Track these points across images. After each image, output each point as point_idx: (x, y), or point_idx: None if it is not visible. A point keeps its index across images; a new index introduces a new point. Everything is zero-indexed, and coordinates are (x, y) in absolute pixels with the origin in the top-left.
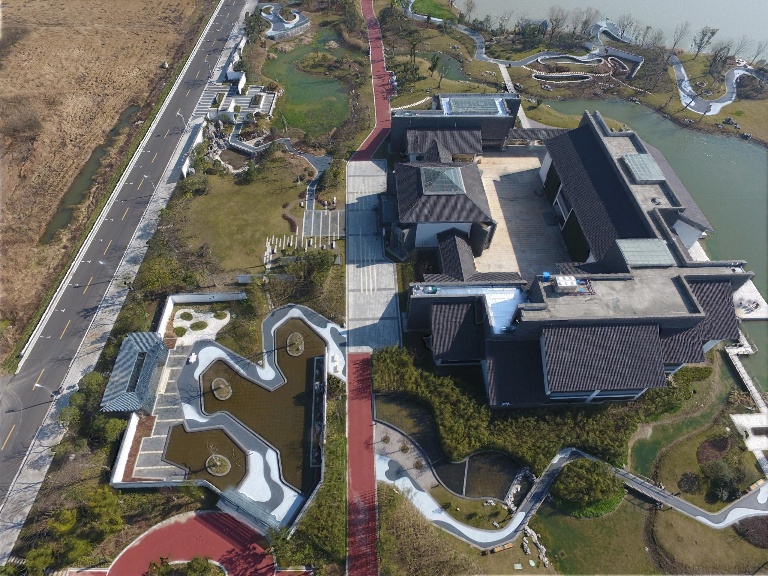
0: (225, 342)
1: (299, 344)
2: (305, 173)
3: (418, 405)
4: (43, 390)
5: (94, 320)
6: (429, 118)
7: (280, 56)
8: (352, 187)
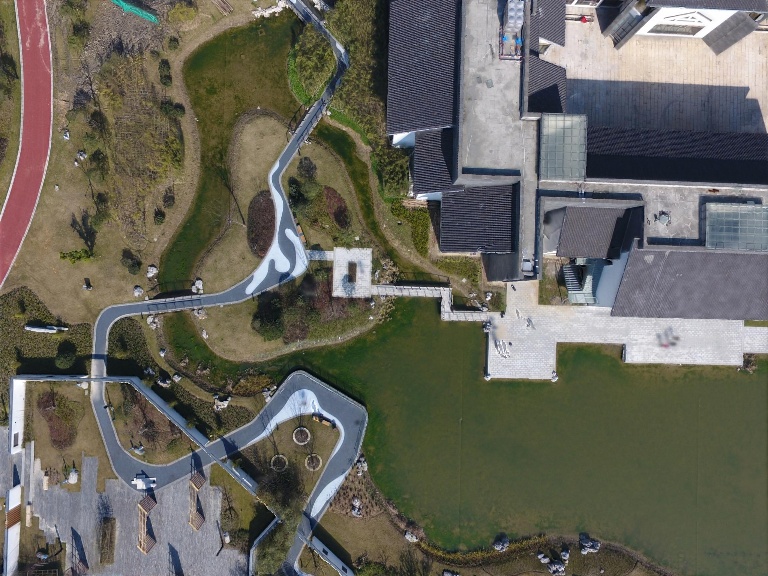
0: None
1: None
2: None
3: None
4: None
5: None
6: None
7: None
8: None
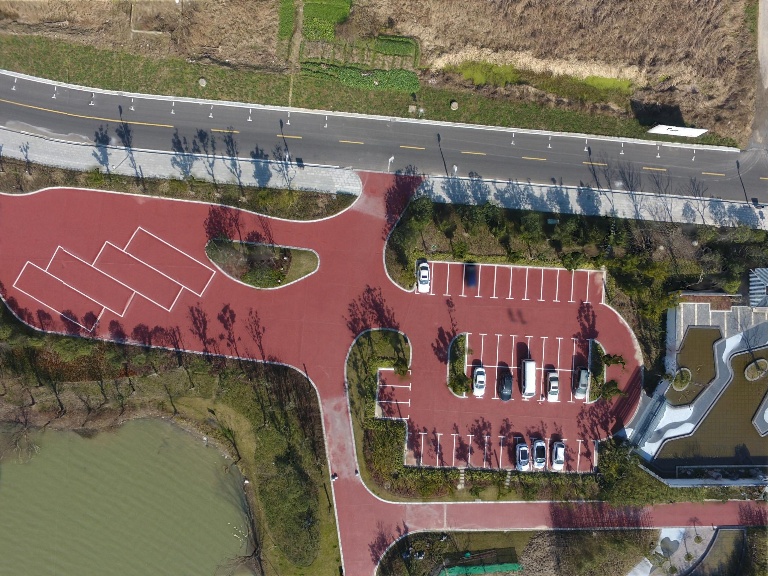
0: None
1: None
2: None
3: (732, 575)
4: (760, 188)
5: None
6: None
7: None
8: None
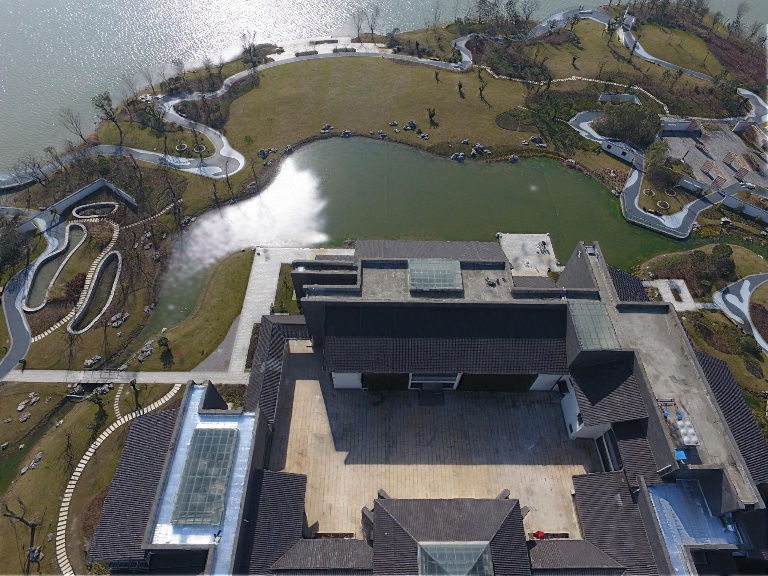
0: None
1: None
2: None
3: None
4: None
5: None
6: None
7: None
8: None
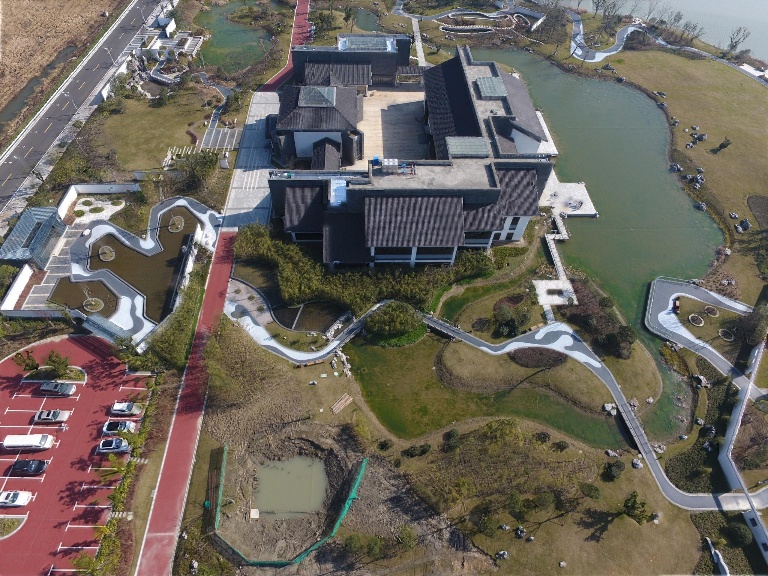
0: (116, 221)
1: (179, 224)
2: (213, 99)
3: (270, 268)
4: None
5: (8, 204)
6: (323, 52)
7: (213, 9)
8: (254, 112)
